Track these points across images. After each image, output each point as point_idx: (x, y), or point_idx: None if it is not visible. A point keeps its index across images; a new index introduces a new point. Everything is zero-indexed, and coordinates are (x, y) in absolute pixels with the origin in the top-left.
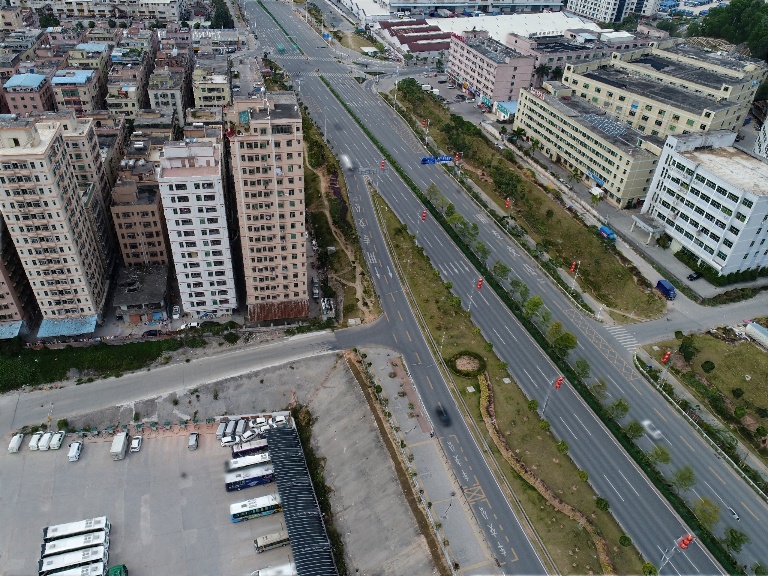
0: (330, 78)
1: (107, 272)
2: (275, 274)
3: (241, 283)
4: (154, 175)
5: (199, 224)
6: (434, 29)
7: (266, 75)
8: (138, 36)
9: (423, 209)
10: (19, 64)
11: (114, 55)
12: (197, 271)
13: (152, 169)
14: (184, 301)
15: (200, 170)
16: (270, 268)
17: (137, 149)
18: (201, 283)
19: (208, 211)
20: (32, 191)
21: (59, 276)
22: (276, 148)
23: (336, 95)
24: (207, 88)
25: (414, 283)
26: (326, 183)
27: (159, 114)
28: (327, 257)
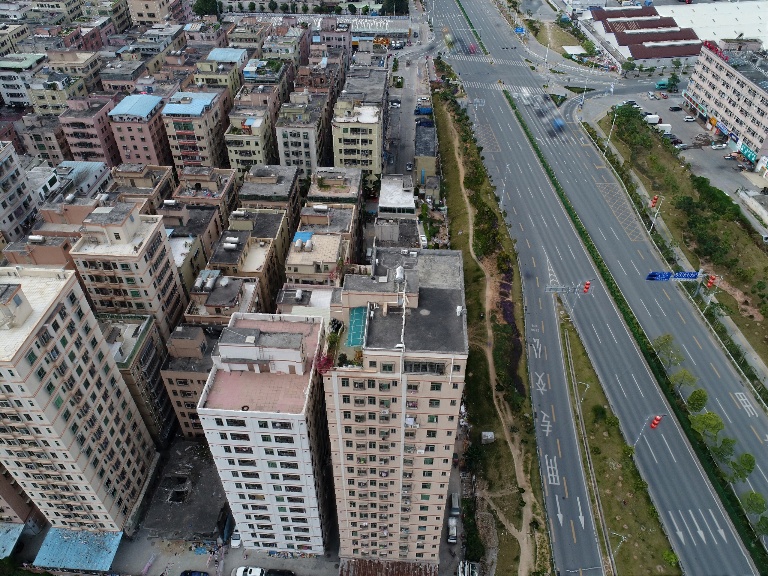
0: (517, 94)
1: (161, 436)
2: (388, 532)
3: (336, 511)
4: (240, 302)
5: (267, 466)
6: (667, 22)
7: (436, 86)
8: (284, 38)
9: (643, 366)
10: (143, 74)
11: (246, 70)
12: (263, 513)
13: (236, 297)
14: (244, 539)
15: (276, 384)
16: (380, 526)
17: (227, 250)
18: (270, 525)
19: (282, 454)
20: (4, 402)
21: (63, 492)
22: (409, 392)
23: (523, 125)
24: (350, 128)
25: (623, 555)
26: (494, 291)
27: (275, 179)
28: (479, 458)
